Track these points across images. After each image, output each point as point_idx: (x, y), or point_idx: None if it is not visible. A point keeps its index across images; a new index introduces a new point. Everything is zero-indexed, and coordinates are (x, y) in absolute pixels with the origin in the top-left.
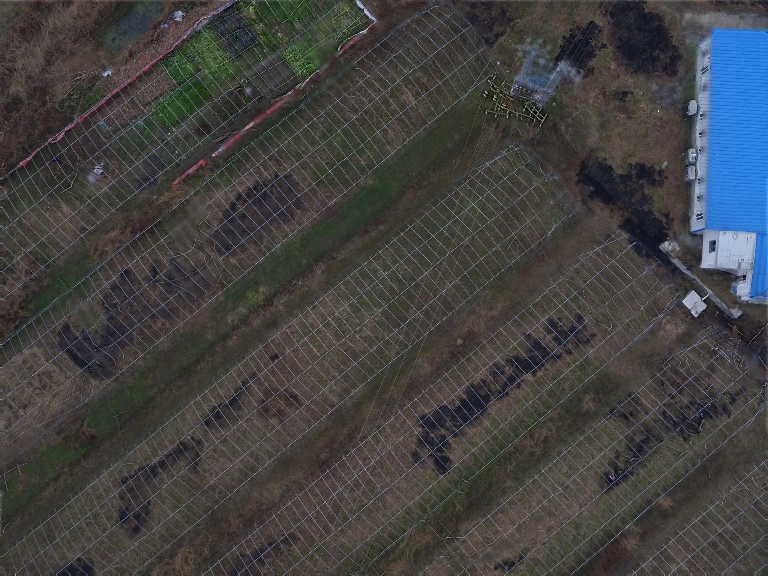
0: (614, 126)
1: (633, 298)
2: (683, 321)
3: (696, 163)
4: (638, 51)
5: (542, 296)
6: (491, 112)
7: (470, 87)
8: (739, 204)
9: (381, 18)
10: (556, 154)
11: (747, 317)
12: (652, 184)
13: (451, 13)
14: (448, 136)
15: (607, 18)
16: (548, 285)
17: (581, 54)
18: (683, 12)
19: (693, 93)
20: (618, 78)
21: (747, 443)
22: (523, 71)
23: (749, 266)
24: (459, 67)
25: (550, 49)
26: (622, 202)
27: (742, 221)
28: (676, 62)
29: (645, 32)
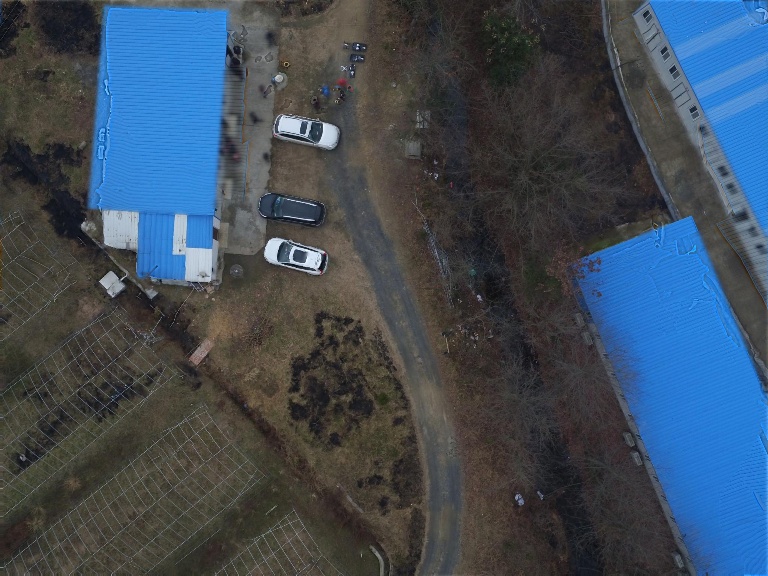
0: (33, 106)
1: (15, 278)
2: (101, 302)
3: (105, 143)
4: (62, 30)
5: None
6: None
7: None
8: (156, 184)
9: None
10: None
11: (164, 298)
12: (70, 164)
13: None
14: None
15: None
16: None
17: (3, 34)
18: None
19: None
20: (40, 58)
21: (138, 424)
22: None
23: None
24: None
25: None
26: (44, 183)
27: (158, 201)
28: (101, 41)
29: (71, 11)
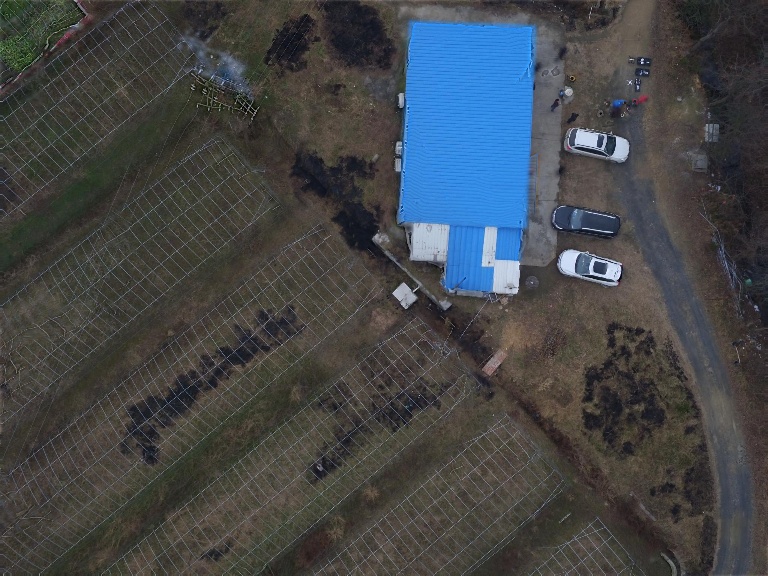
0: (325, 119)
1: (326, 290)
2: (393, 313)
3: (402, 156)
4: (352, 44)
5: (240, 288)
6: (203, 105)
7: (172, 80)
8: (449, 197)
9: (93, 12)
10: (270, 147)
11: (457, 309)
12: (363, 177)
13: (151, 7)
14: (150, 129)
15: (321, 11)
16: (248, 277)
17: (294, 47)
18: (399, 5)
19: (401, 86)
20: (331, 71)
21: (444, 434)
22: (235, 64)
23: (445, 258)
24: (157, 61)
25: (262, 42)
26: (334, 195)
27: (452, 214)
28: (390, 55)
29: (360, 25)
